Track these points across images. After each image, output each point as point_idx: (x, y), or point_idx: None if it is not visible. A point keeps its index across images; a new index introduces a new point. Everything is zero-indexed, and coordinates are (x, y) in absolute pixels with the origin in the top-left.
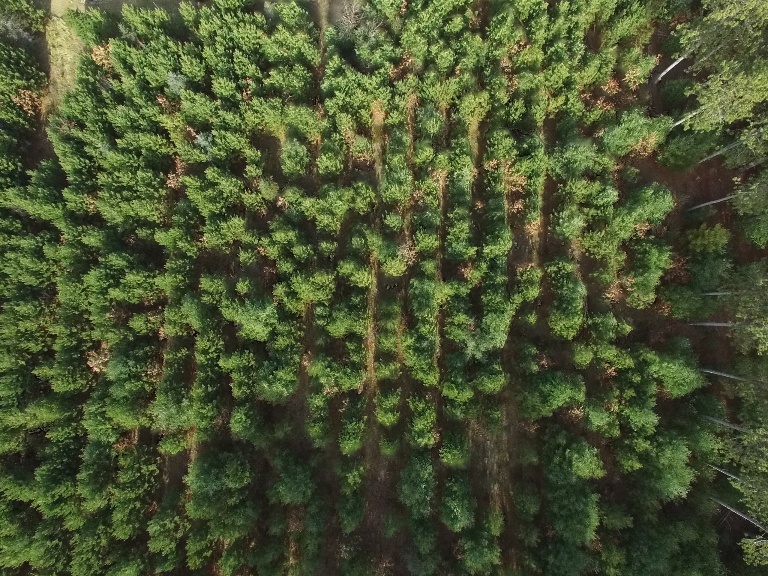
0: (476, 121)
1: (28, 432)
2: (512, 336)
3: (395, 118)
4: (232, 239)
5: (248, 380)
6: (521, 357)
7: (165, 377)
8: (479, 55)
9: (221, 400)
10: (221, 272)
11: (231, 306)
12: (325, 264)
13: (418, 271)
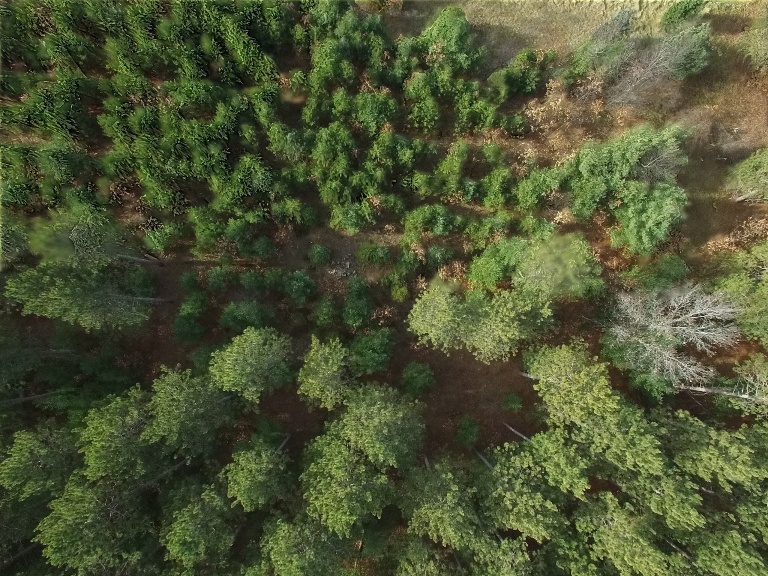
0: None
1: None
2: None
3: None
4: None
5: None
6: None
7: None
8: None
9: None
10: None
11: None
12: None
13: None
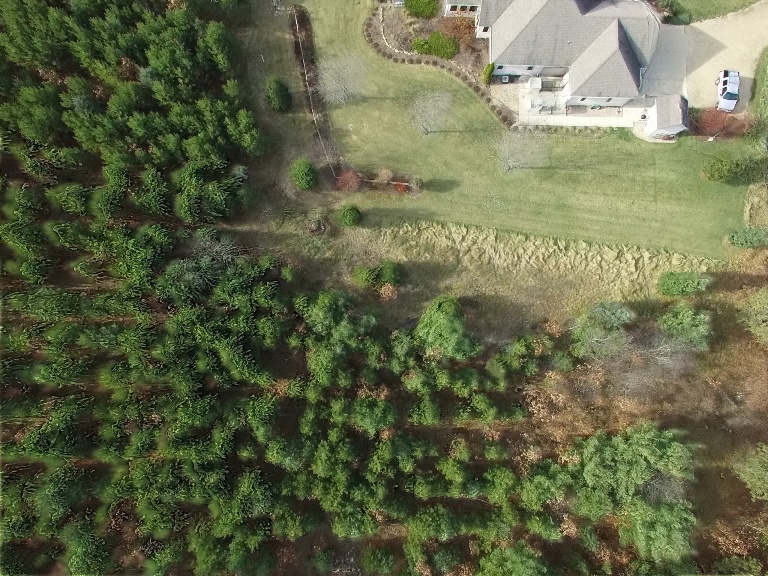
0: None
1: None
2: None
3: None
4: None
5: None
6: None
7: None
8: None
9: None
10: None
11: None
12: None
13: None
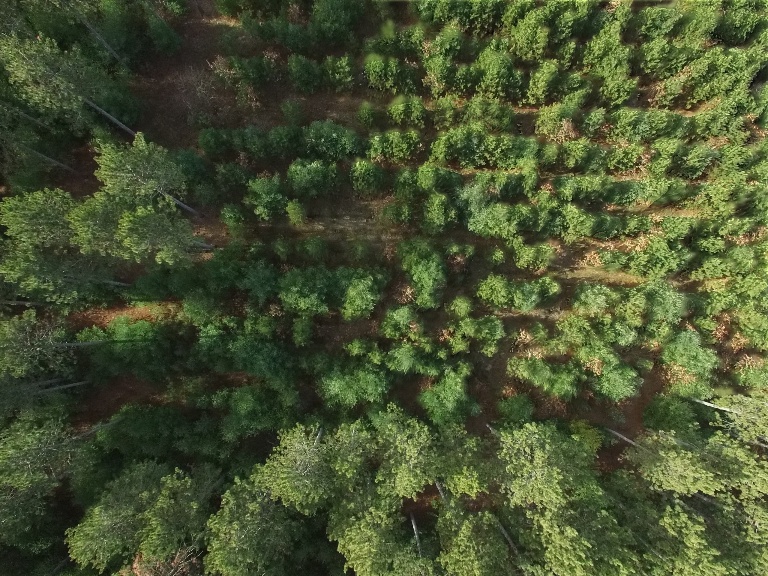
0: (692, 215)
1: None
2: None
3: (704, 118)
4: None
5: None
6: None
7: None
8: (767, 211)
9: None
10: None
11: None
12: (549, 52)
13: (544, 144)
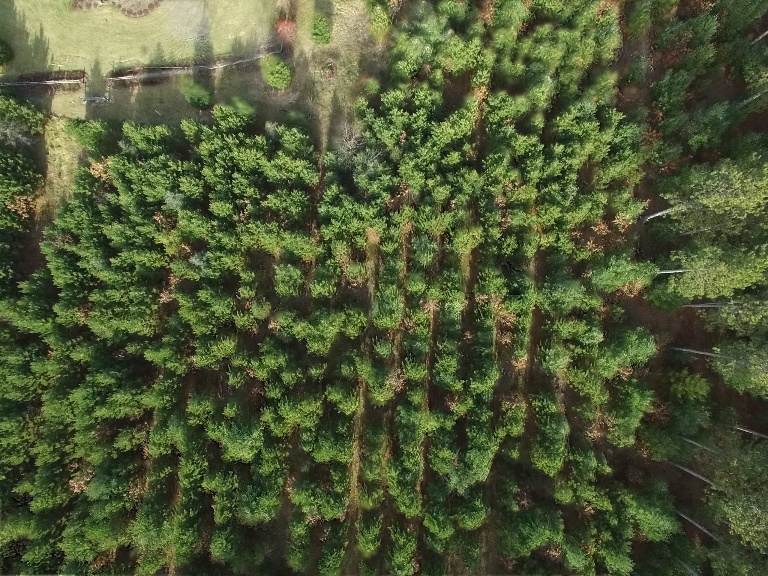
0: (469, 247)
1: (3, 556)
2: (495, 462)
3: (390, 248)
4: (222, 357)
5: (231, 504)
6: (503, 491)
7: (147, 499)
8: (475, 187)
9: (202, 522)
10: (209, 391)
11: (217, 430)
12: (313, 387)
13: (405, 399)
